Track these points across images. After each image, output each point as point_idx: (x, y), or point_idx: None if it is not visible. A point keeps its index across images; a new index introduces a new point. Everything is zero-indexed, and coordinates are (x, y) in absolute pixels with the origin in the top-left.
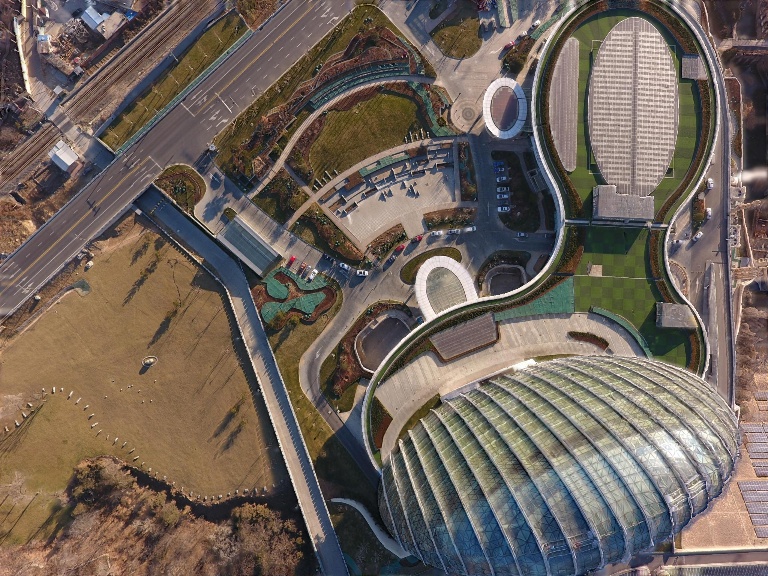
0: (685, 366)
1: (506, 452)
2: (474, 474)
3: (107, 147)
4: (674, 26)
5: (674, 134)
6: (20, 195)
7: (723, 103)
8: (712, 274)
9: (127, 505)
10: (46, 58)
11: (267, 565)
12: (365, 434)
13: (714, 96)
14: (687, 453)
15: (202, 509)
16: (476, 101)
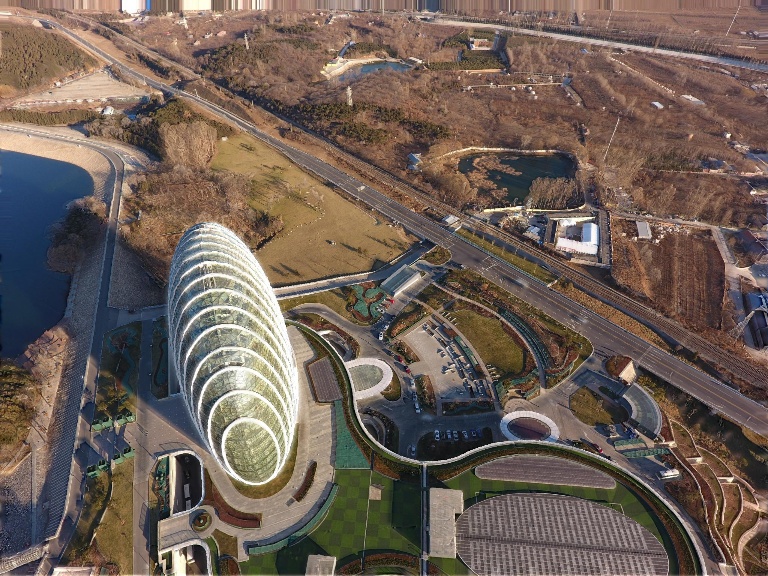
0: None
1: None
2: None
3: (457, 229)
4: None
5: None
6: (428, 210)
7: None
8: None
9: None
10: (505, 215)
11: None
12: None
13: None
14: None
15: None
16: None
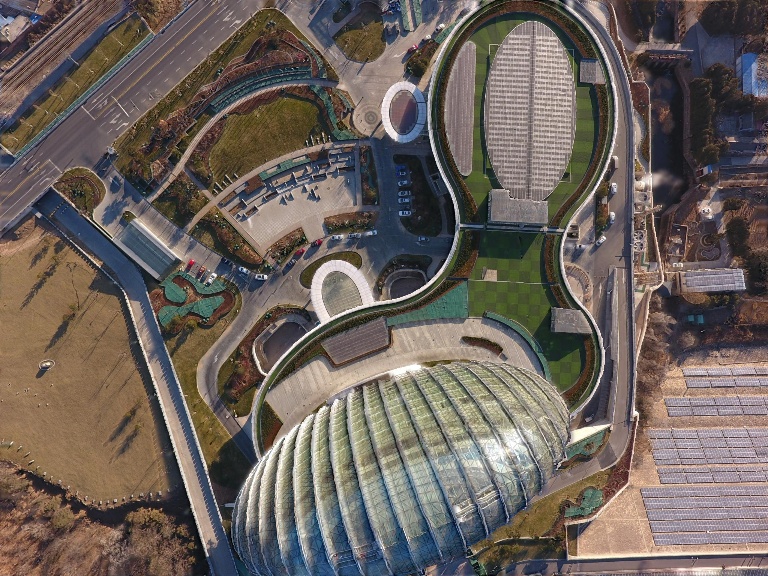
0: (580, 372)
1: (326, 460)
2: (293, 482)
3: (6, 150)
4: (572, 30)
5: (571, 138)
6: None
7: (628, 107)
8: (615, 279)
9: (22, 509)
10: None
11: (154, 570)
12: (255, 439)
13: (612, 100)
14: (485, 462)
15: (97, 513)
16: (379, 105)
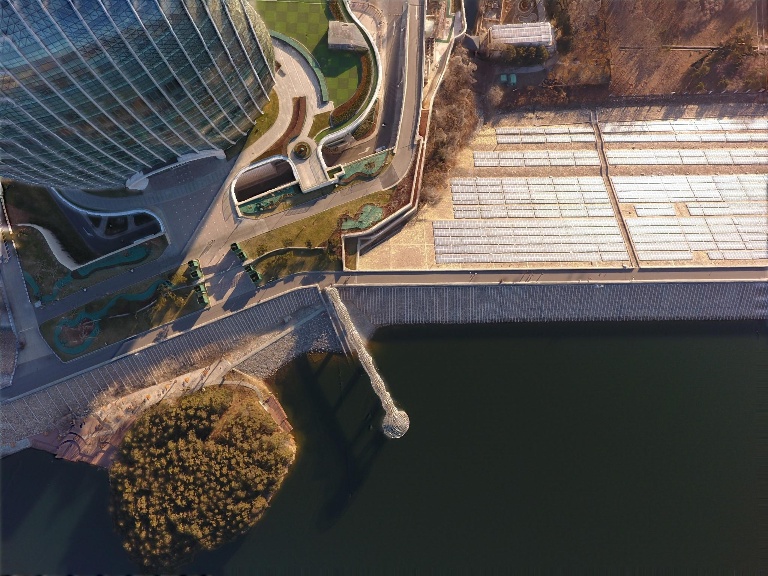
0: (357, 87)
1: None
2: None
3: None
4: None
5: None
6: None
7: None
8: (407, 15)
9: None
10: None
11: None
12: None
13: None
14: None
15: None
16: None
